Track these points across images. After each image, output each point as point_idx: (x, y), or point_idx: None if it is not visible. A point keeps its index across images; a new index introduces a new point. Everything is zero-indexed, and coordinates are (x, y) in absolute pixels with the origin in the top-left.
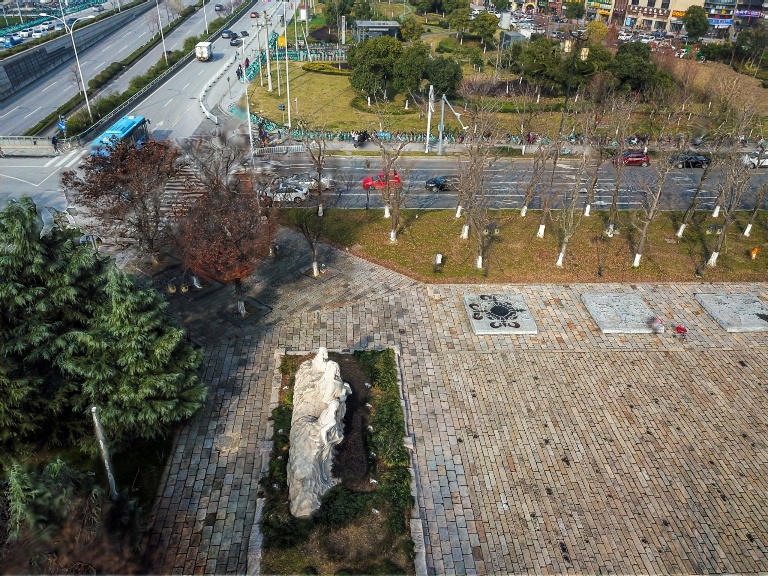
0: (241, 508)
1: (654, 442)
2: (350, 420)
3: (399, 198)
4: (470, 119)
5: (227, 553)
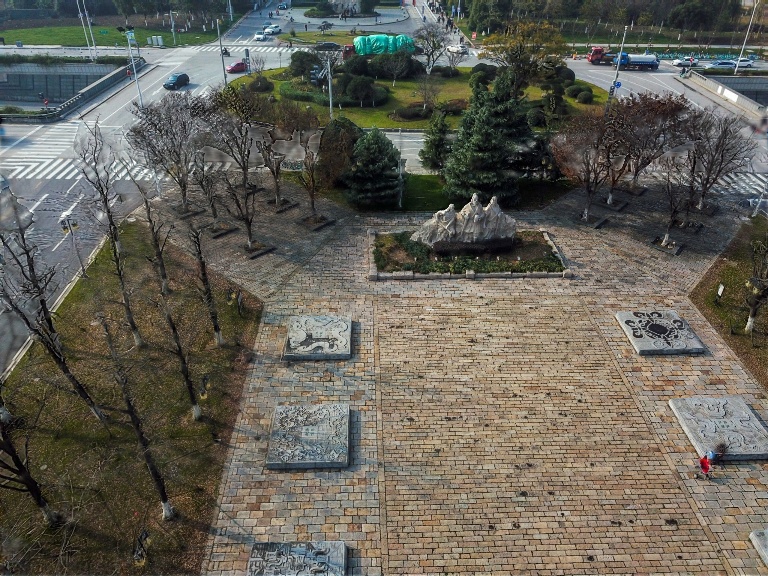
0: None
1: (503, 395)
2: (475, 244)
3: None
4: None
5: (395, 229)
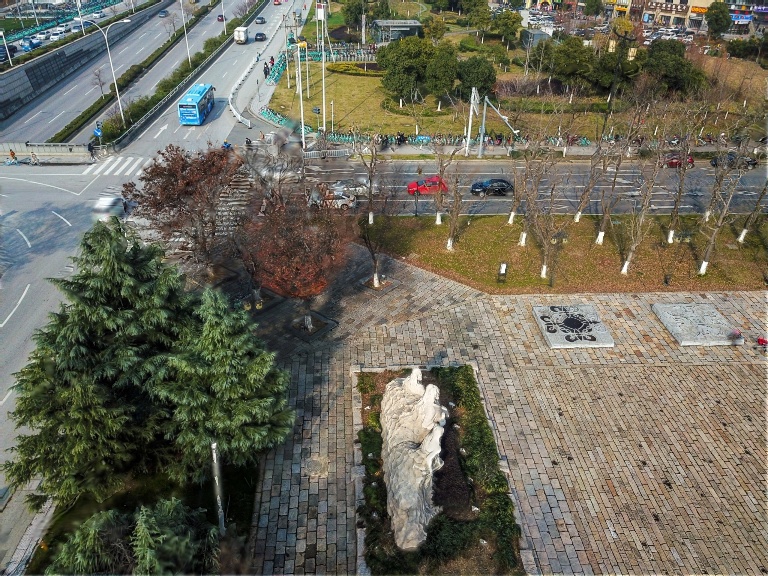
0: (341, 538)
1: (755, 463)
2: (443, 443)
3: (458, 206)
4: (511, 121)
5: None
